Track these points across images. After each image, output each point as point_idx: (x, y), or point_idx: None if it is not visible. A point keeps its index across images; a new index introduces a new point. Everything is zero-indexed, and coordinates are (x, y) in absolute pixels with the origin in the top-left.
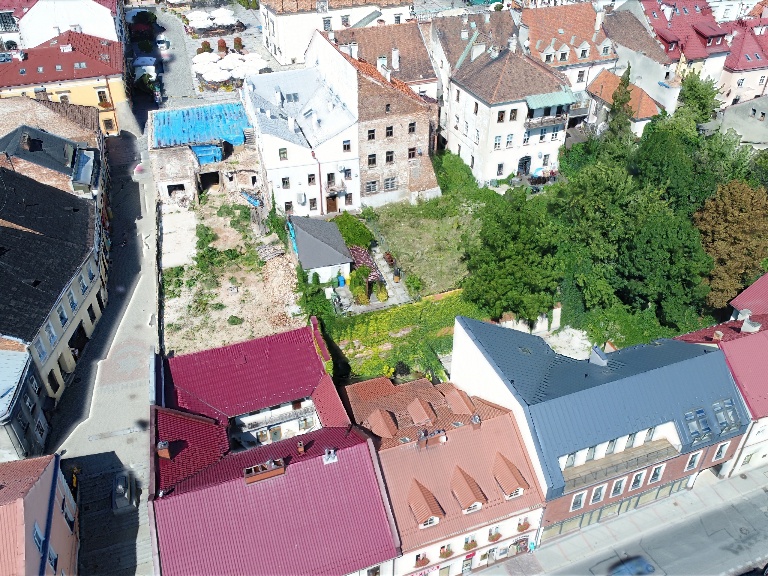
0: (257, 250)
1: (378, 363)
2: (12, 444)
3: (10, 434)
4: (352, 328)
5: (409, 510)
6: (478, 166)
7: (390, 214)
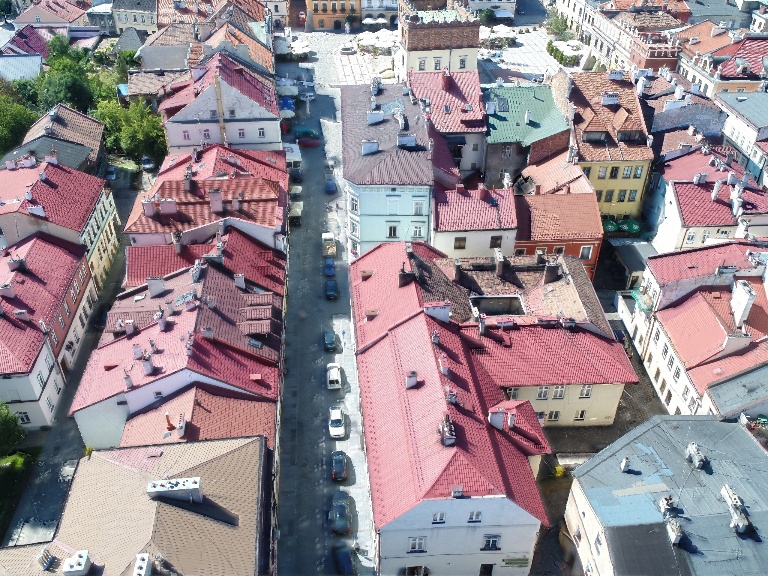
0: None
1: None
2: None
3: None
4: None
5: None
6: None
7: None
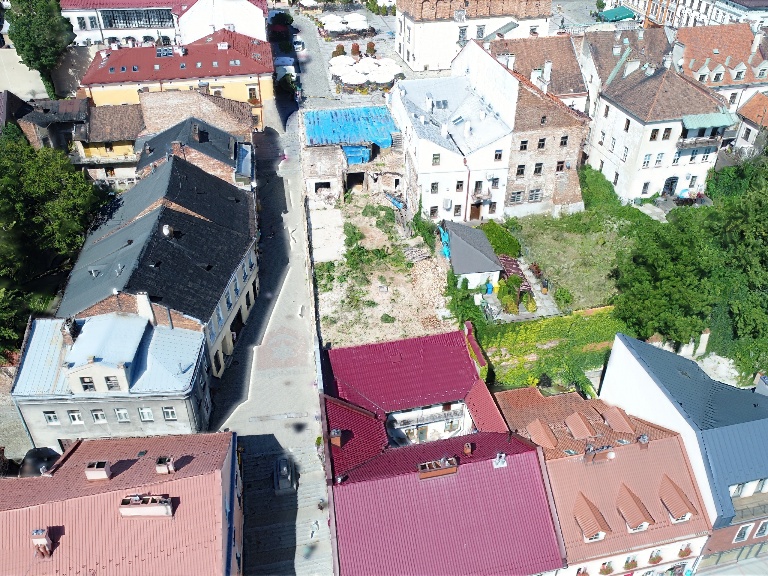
0: (404, 251)
1: (522, 373)
2: (188, 418)
3: (188, 408)
4: (502, 336)
5: (574, 522)
6: (622, 183)
7: (533, 225)
